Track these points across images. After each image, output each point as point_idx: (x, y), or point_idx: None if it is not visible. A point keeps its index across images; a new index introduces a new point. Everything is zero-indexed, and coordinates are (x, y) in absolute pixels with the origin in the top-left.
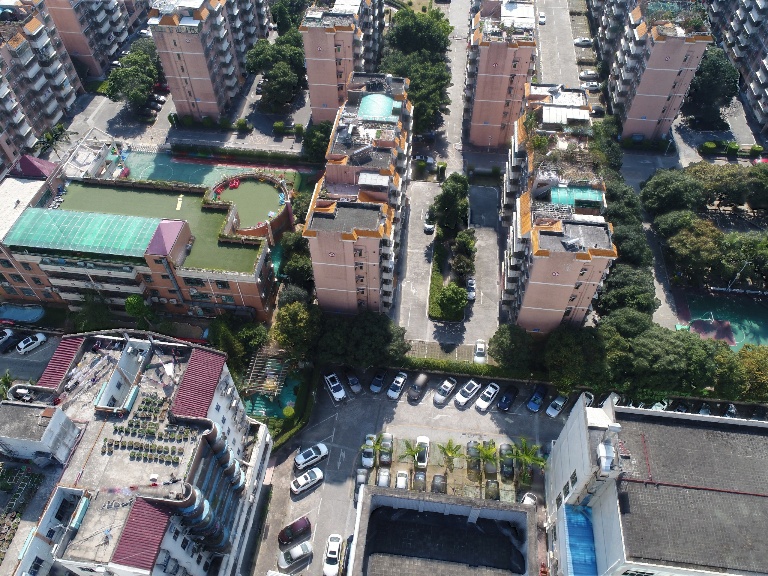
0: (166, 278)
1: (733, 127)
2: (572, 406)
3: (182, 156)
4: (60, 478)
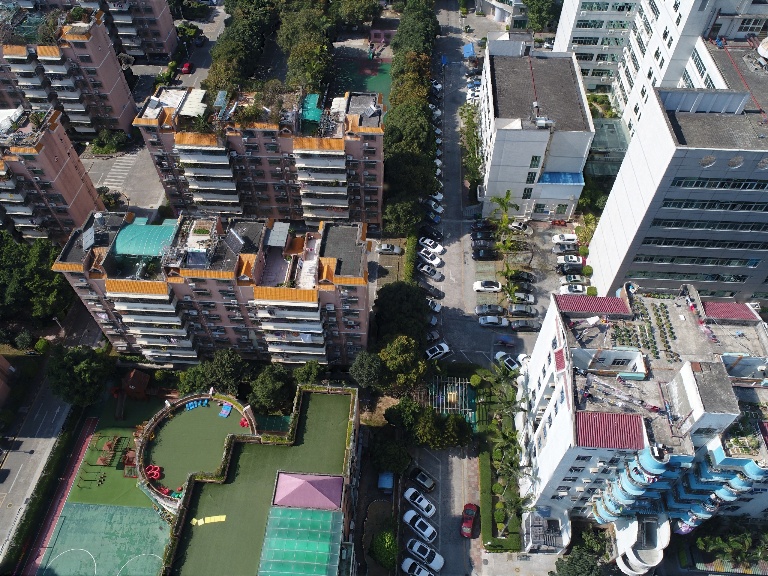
0: (346, 509)
1: (135, 73)
2: (433, 199)
3: None
4: None
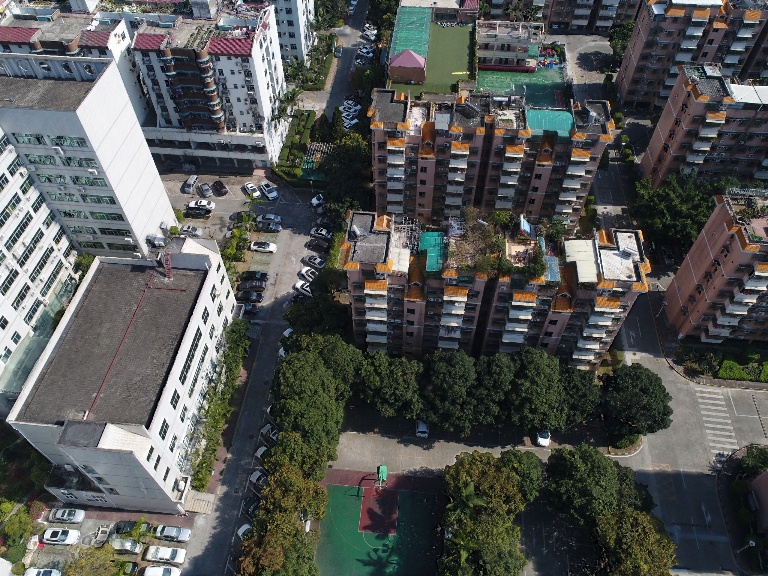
0: None
1: None
2: None
3: (564, 95)
4: (187, 18)
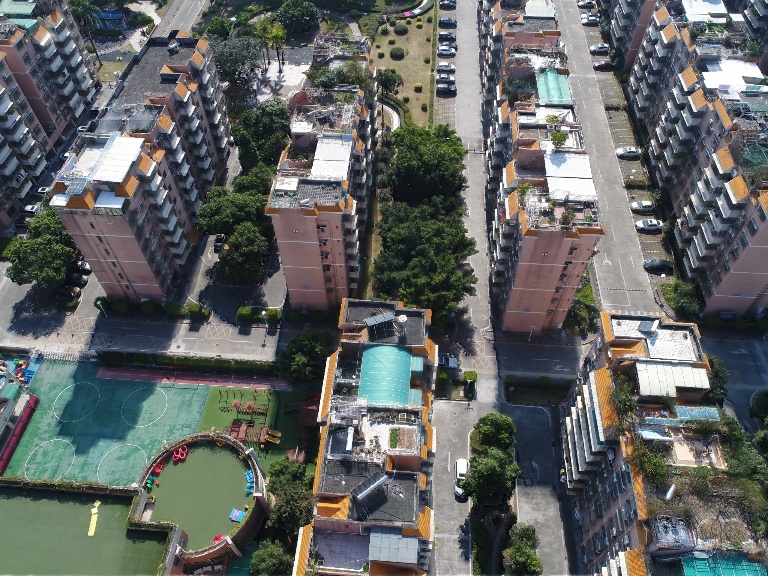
0: None
1: None
2: None
3: (113, 366)
4: None
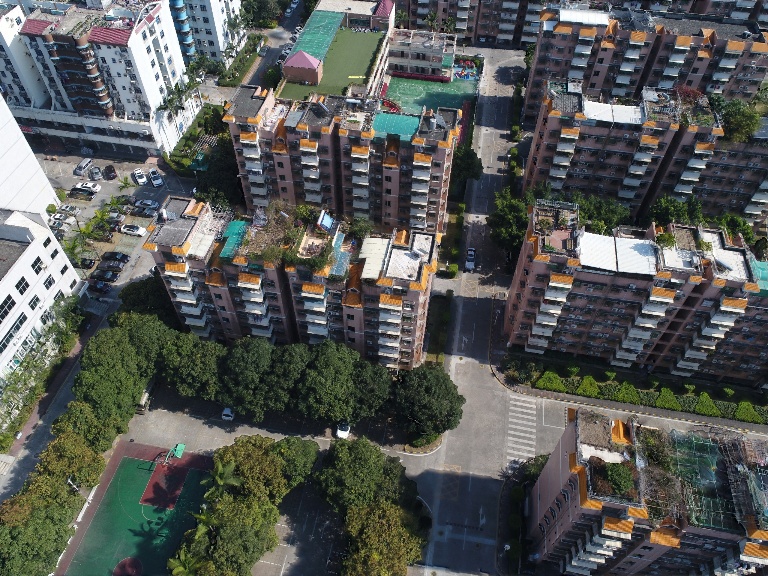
0: None
1: None
2: None
3: None
4: (81, 7)
